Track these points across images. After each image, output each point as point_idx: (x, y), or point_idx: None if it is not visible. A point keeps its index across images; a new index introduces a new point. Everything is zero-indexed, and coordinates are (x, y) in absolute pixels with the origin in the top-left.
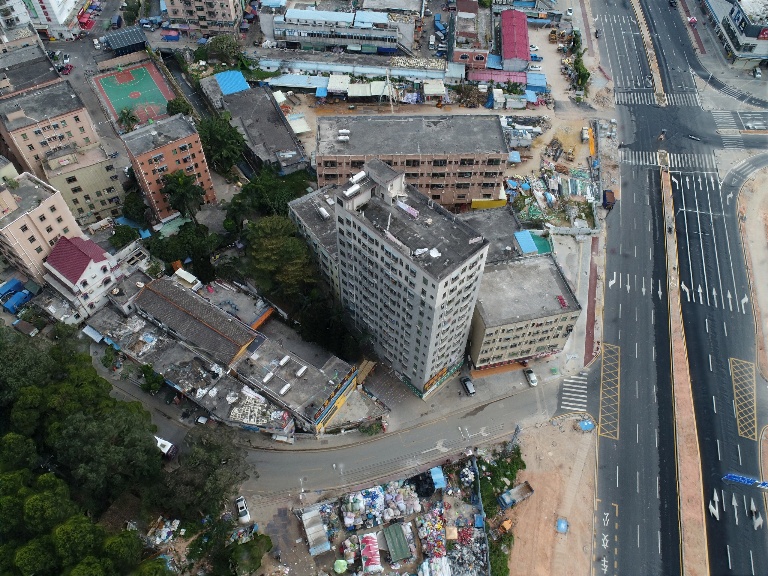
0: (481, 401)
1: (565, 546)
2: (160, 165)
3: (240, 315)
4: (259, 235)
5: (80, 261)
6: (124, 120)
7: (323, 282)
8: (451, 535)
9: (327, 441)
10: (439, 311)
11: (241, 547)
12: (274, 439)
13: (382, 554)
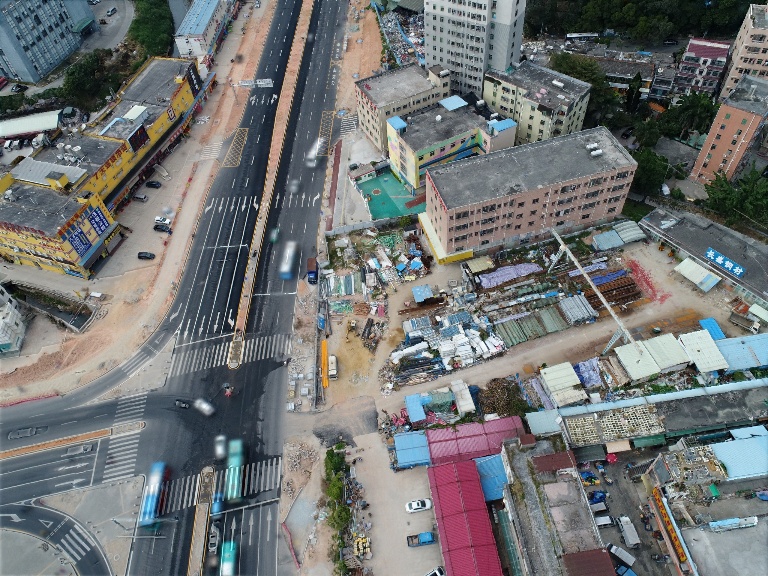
0: None
1: (354, 71)
2: None
3: None
4: None
5: None
6: None
7: None
8: (411, 48)
9: None
10: None
11: None
12: None
13: None
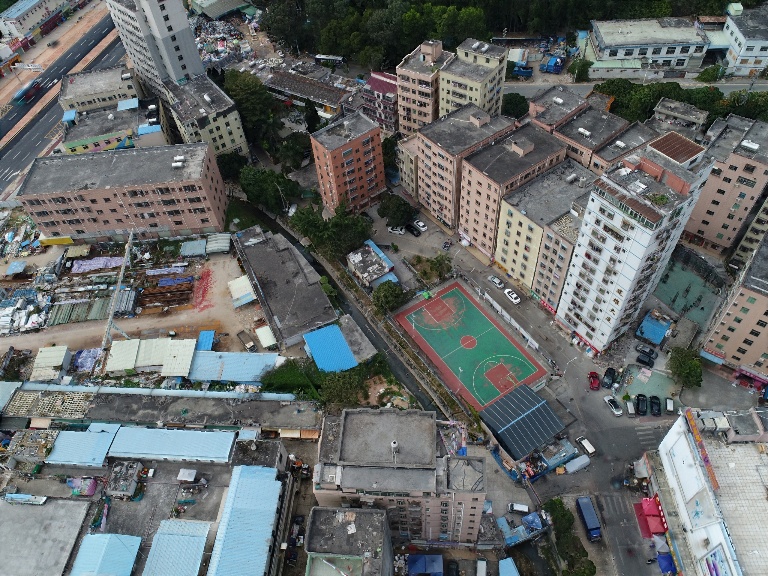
0: None
1: None
2: None
3: None
4: None
5: (381, 74)
6: None
7: None
8: None
9: None
10: None
11: None
12: None
13: None
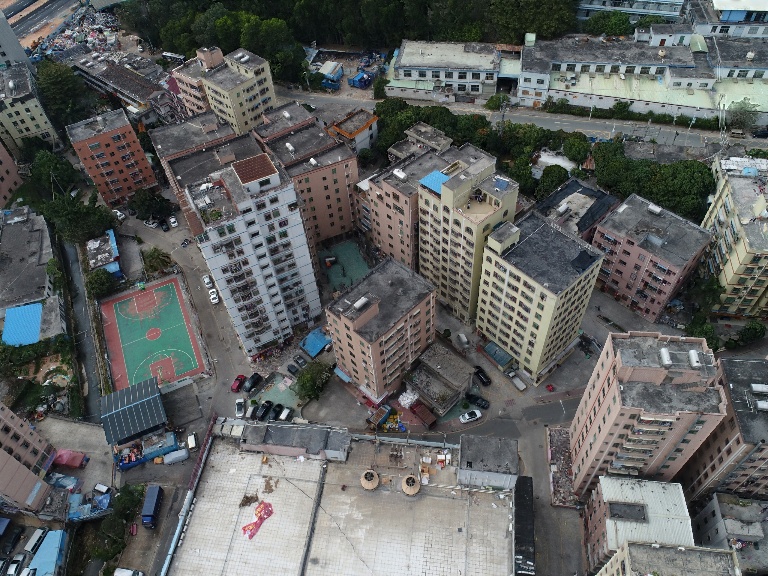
0: None
1: None
2: None
3: None
4: None
5: None
6: None
7: None
8: None
9: None
10: None
11: None
12: None
13: None
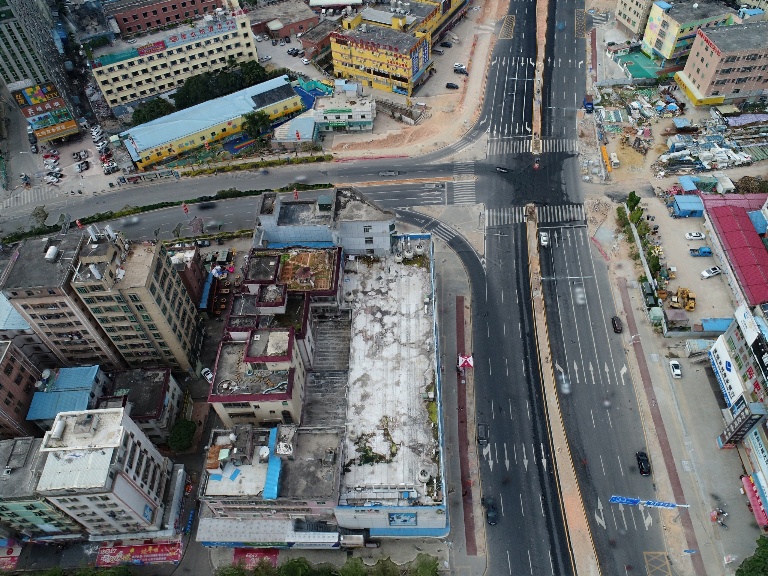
0: None
1: None
2: None
3: None
4: None
5: None
6: None
7: None
8: None
9: None
10: None
11: None
12: None
13: None
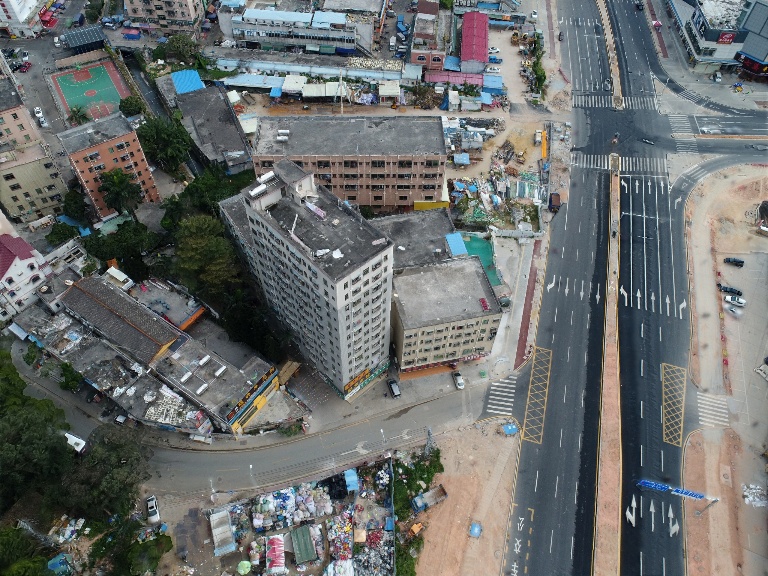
0: (406, 403)
1: (476, 550)
2: (97, 163)
3: (171, 314)
4: (185, 234)
5: (5, 258)
6: (74, 118)
7: (253, 282)
8: (359, 538)
9: (246, 442)
10: (344, 312)
11: (139, 547)
12: (191, 439)
13: (288, 556)
